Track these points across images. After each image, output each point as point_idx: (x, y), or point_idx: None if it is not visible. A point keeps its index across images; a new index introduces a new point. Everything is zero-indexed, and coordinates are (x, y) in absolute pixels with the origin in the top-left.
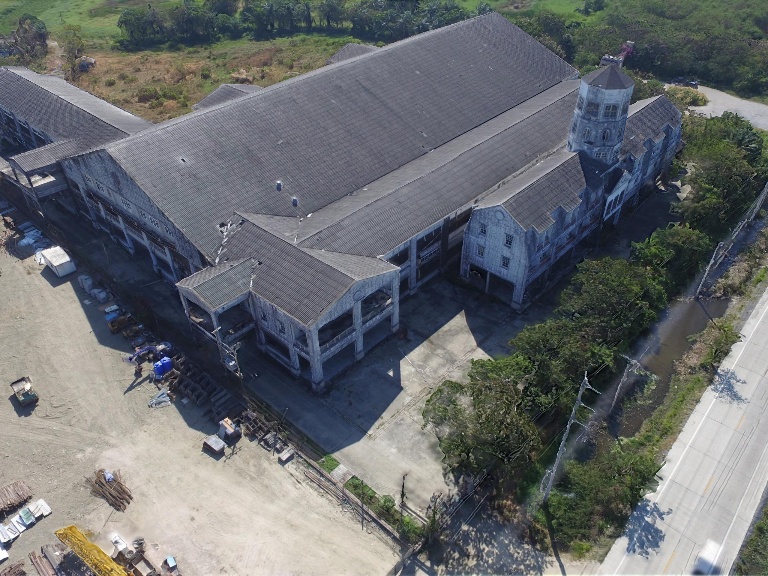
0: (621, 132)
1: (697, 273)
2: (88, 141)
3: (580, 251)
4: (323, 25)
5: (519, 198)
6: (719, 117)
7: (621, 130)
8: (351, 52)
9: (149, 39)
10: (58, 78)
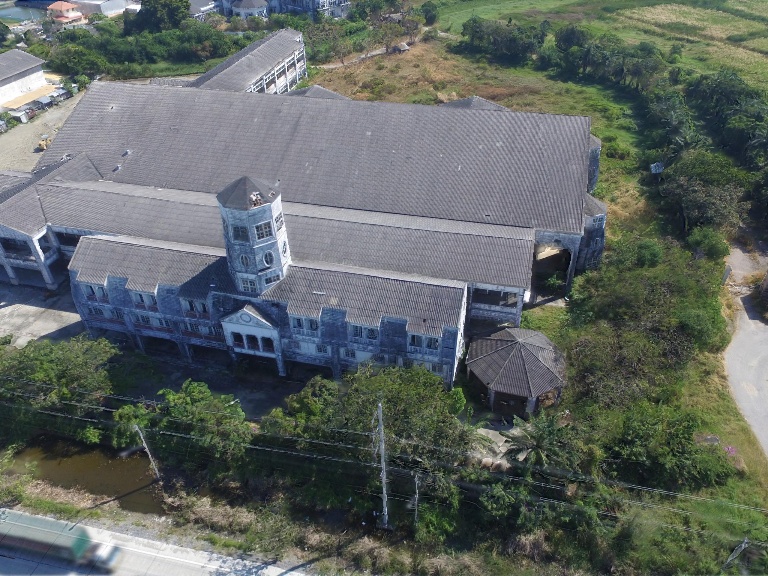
0: (249, 262)
1: (210, 472)
2: (193, 85)
3: (217, 363)
4: (631, 86)
5: (104, 244)
6: (673, 418)
7: (248, 259)
8: (459, 104)
9: (480, 47)
10: (299, 46)
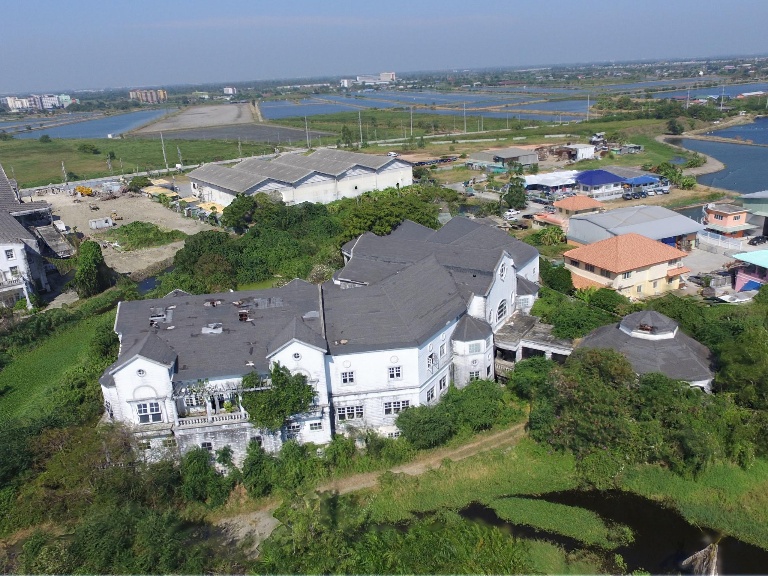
0: None
1: None
2: None
3: None
4: None
5: None
6: None
7: None
8: None
9: None
10: None
